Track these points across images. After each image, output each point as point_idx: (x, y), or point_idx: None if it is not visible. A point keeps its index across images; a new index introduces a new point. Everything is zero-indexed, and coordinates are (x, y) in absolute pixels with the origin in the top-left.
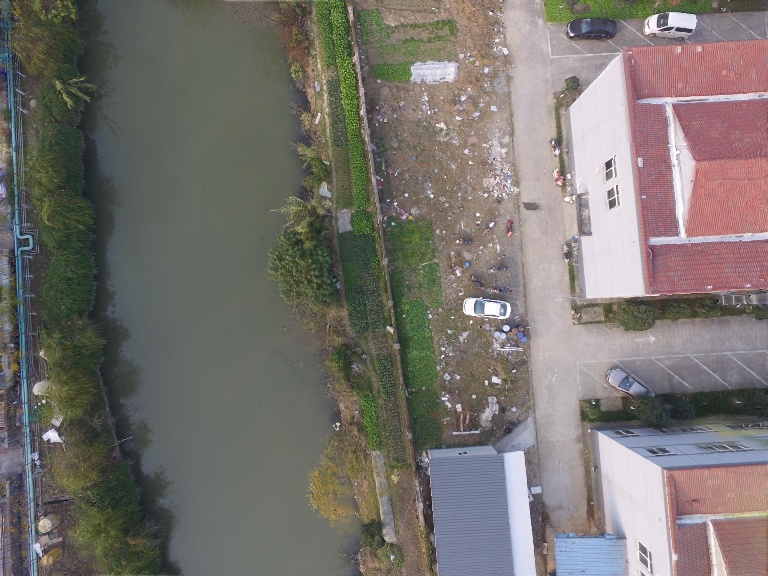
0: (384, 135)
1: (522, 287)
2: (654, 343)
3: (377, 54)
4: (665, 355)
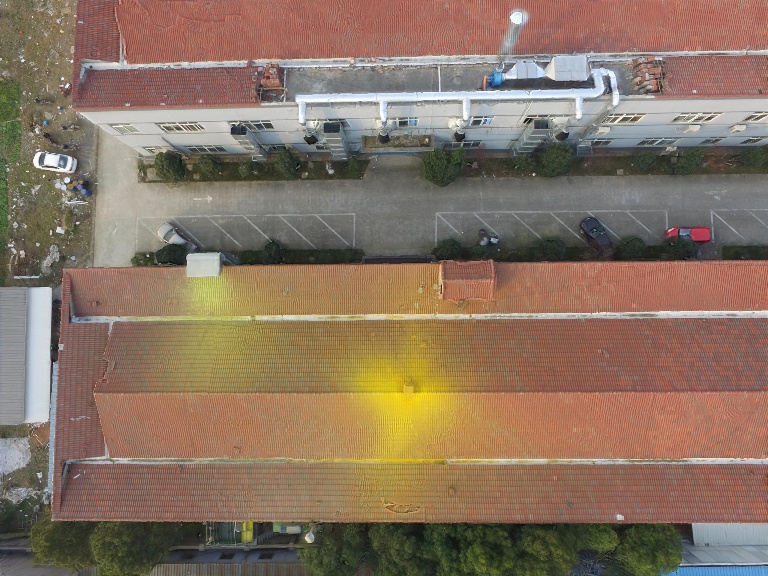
0: None
1: (95, 146)
2: (211, 203)
3: None
4: (220, 214)
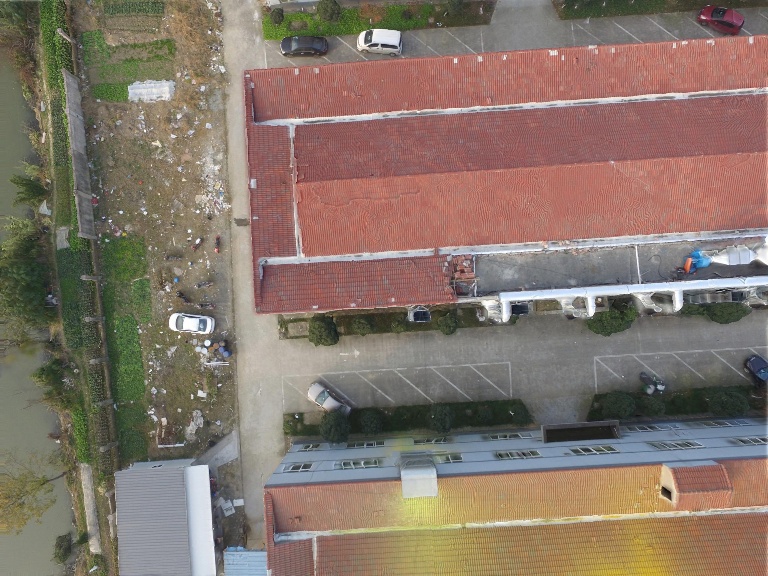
0: (101, 153)
1: (231, 302)
2: (358, 357)
3: (98, 74)
4: (369, 369)
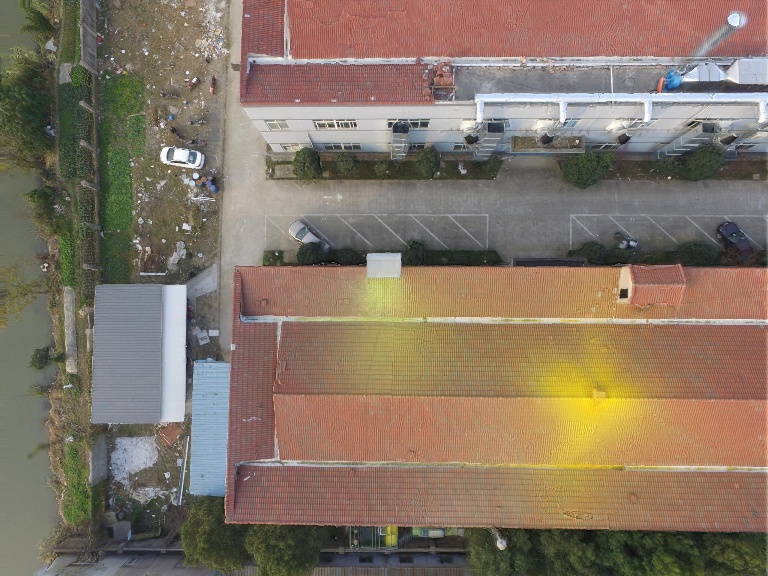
0: None
1: (221, 142)
2: (341, 201)
3: None
4: (350, 213)
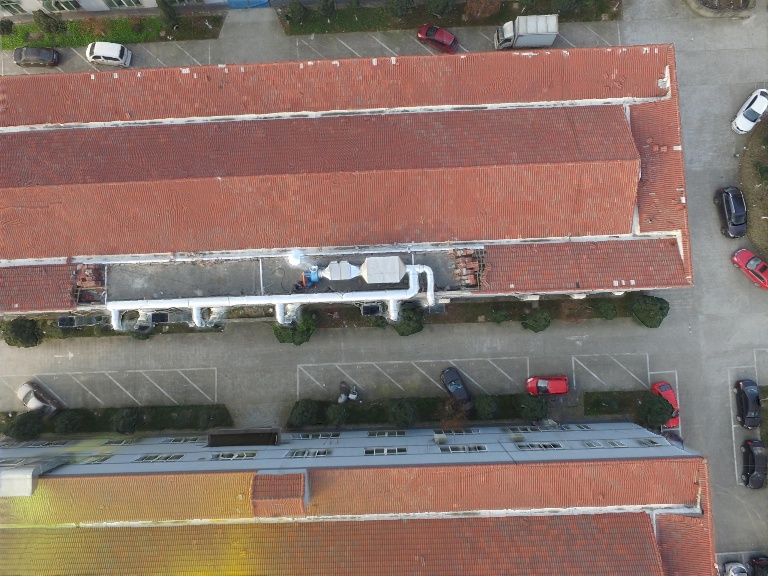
0: None
1: None
2: (72, 359)
3: None
4: (81, 371)
